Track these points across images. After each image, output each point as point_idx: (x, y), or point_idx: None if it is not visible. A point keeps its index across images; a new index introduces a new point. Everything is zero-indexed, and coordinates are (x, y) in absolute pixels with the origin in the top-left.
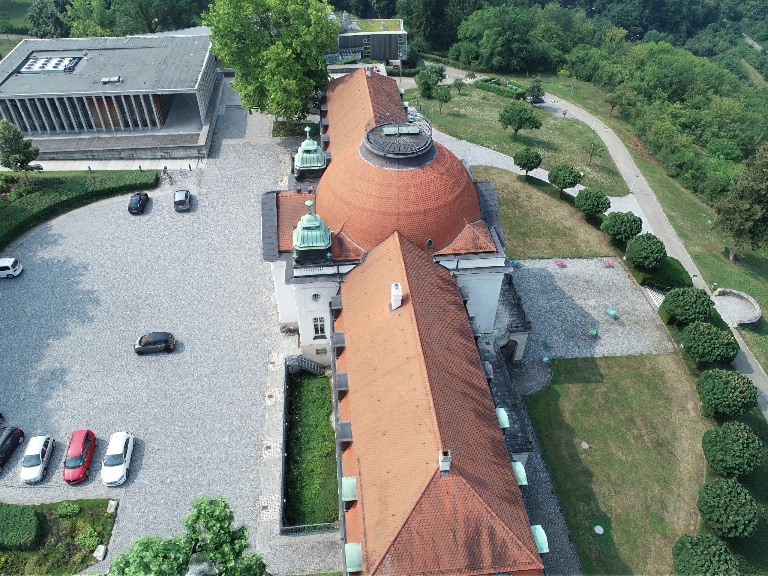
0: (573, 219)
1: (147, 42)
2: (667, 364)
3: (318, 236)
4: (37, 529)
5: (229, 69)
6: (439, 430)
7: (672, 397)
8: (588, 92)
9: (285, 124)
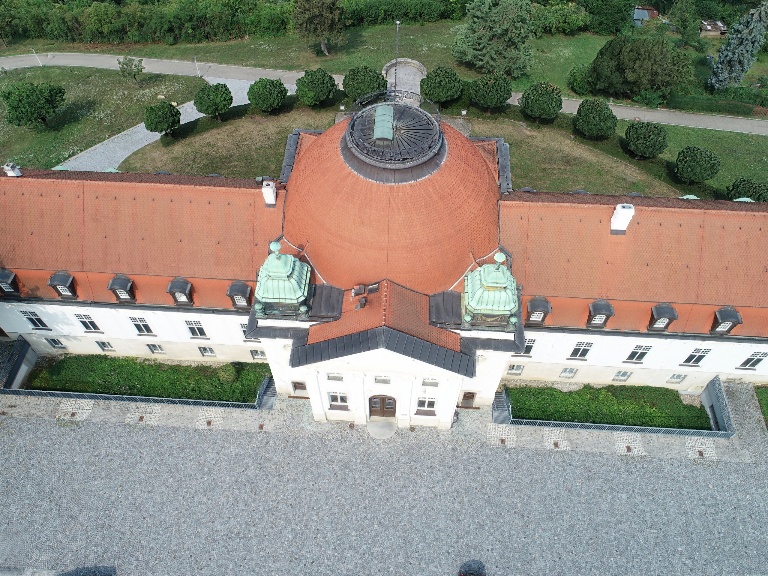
0: (265, 124)
1: None
2: (484, 129)
3: None
4: None
5: None
6: None
7: (519, 139)
8: None
9: None
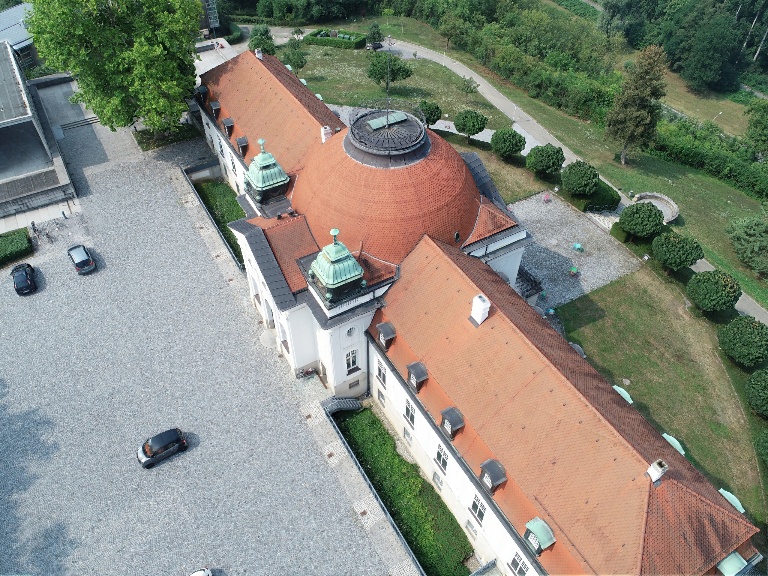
0: (492, 163)
1: None
2: (644, 280)
3: (350, 266)
4: None
5: (38, 79)
6: (626, 440)
7: (664, 309)
8: (415, 28)
9: (149, 132)
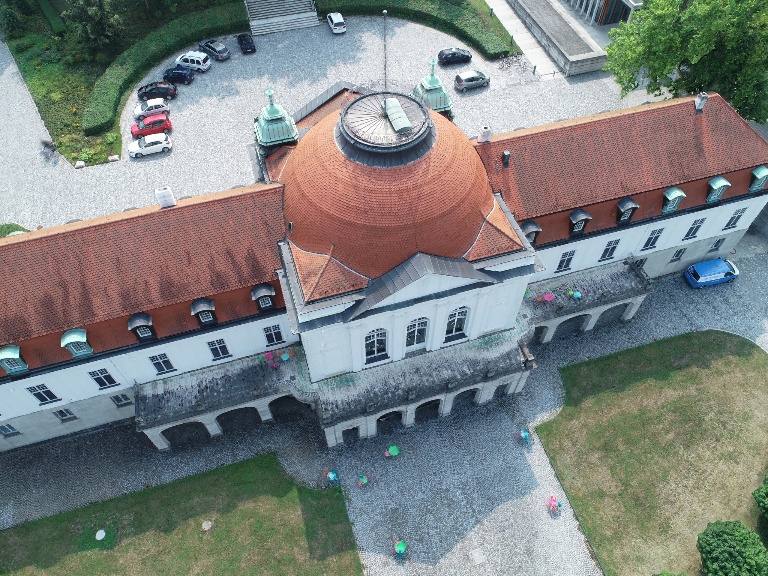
0: None
1: None
2: None
3: None
4: (92, 128)
5: None
6: None
7: None
8: None
9: None
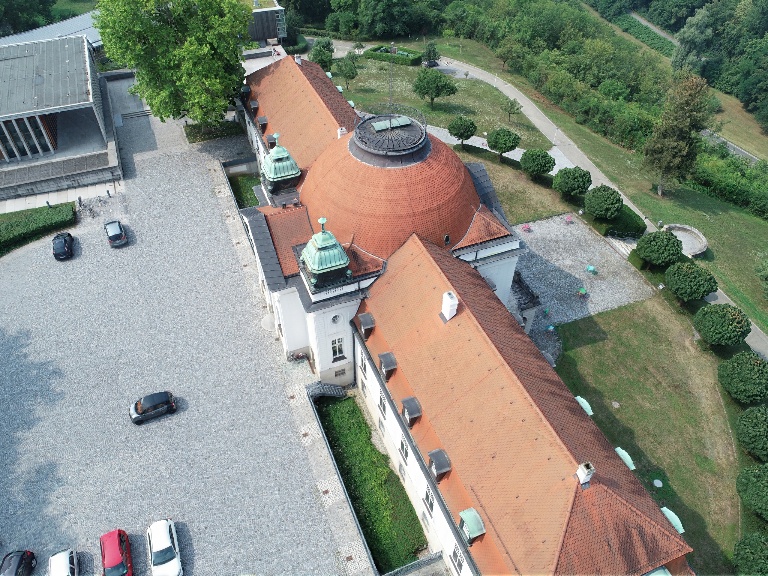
0: (520, 181)
1: (5, 53)
2: (654, 308)
3: (336, 254)
4: None
5: (109, 72)
6: (562, 441)
7: (670, 339)
8: (474, 49)
9: (198, 127)
